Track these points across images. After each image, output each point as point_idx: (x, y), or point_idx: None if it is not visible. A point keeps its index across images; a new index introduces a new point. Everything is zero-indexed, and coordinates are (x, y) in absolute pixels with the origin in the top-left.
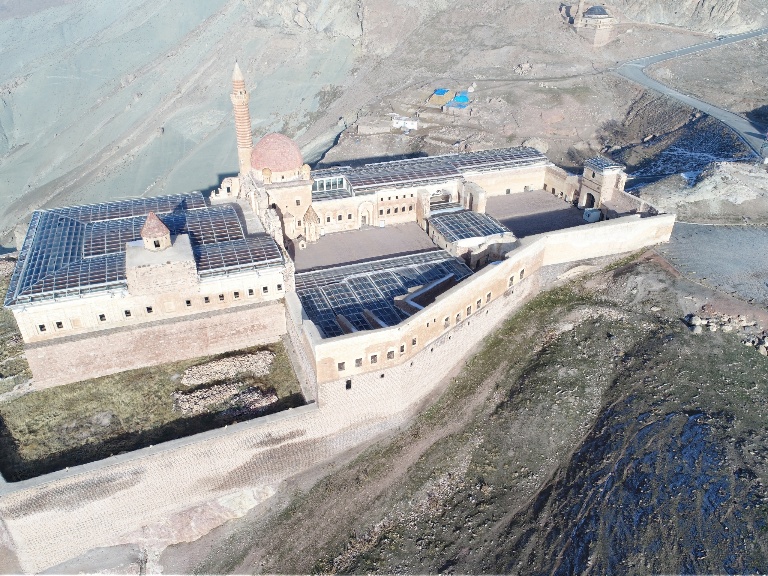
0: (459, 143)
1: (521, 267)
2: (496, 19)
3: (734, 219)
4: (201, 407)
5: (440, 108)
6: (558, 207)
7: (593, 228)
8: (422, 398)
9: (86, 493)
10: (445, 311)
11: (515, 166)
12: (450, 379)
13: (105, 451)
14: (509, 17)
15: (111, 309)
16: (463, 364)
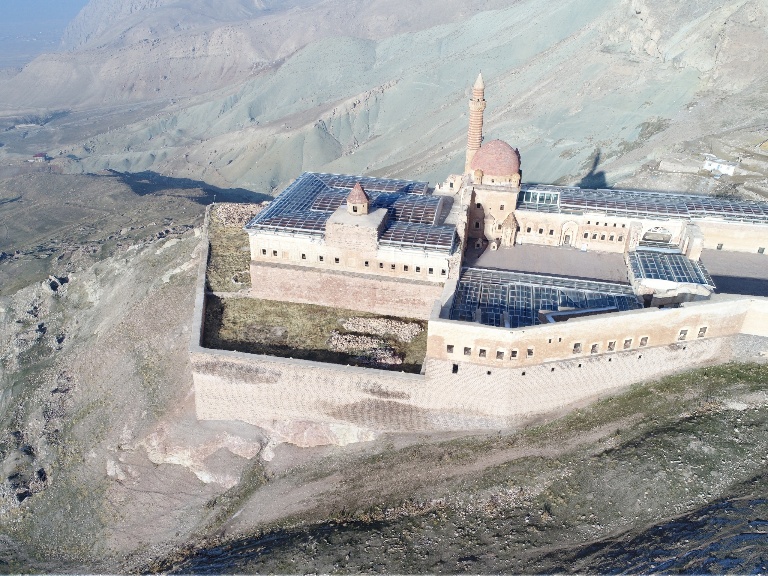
0: None
1: (702, 323)
2: None
3: None
4: (344, 347)
5: None
6: None
7: None
8: (534, 414)
9: (241, 374)
10: (576, 335)
11: None
12: (573, 409)
13: (266, 352)
14: None
15: (310, 251)
16: (594, 400)
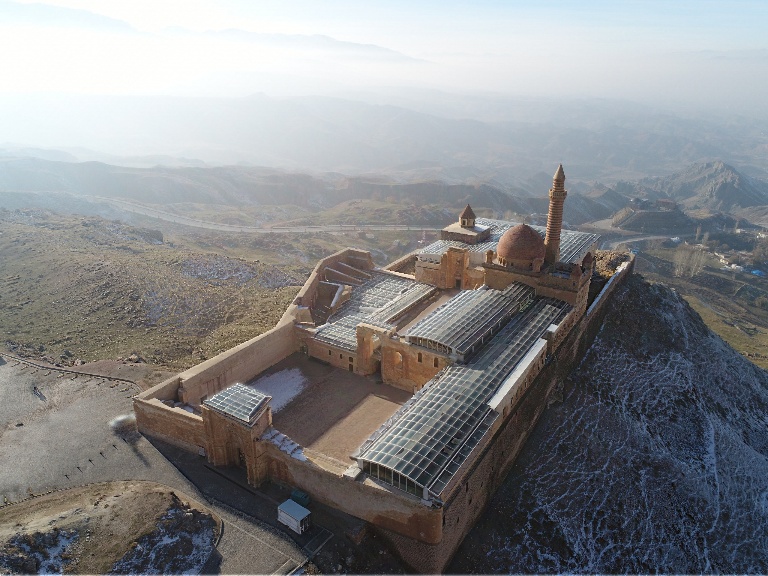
0: None
1: None
2: None
3: (7, 512)
4: None
5: None
6: None
7: (233, 348)
8: None
9: None
10: None
11: None
12: None
13: None
14: None
15: None
16: None
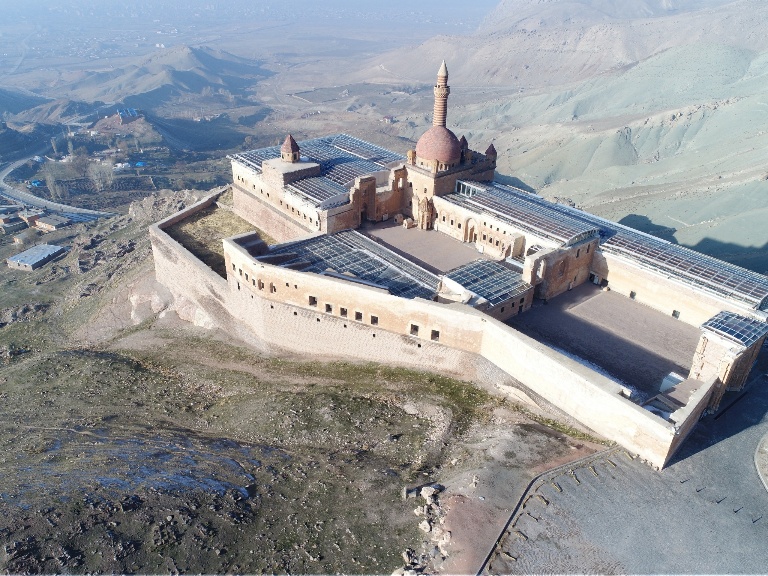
0: None
1: (432, 325)
2: None
3: None
4: None
5: None
6: (682, 360)
7: (537, 350)
8: (288, 350)
9: (165, 252)
10: (310, 288)
11: (697, 286)
12: (316, 359)
13: None
14: None
15: (256, 184)
16: (335, 360)
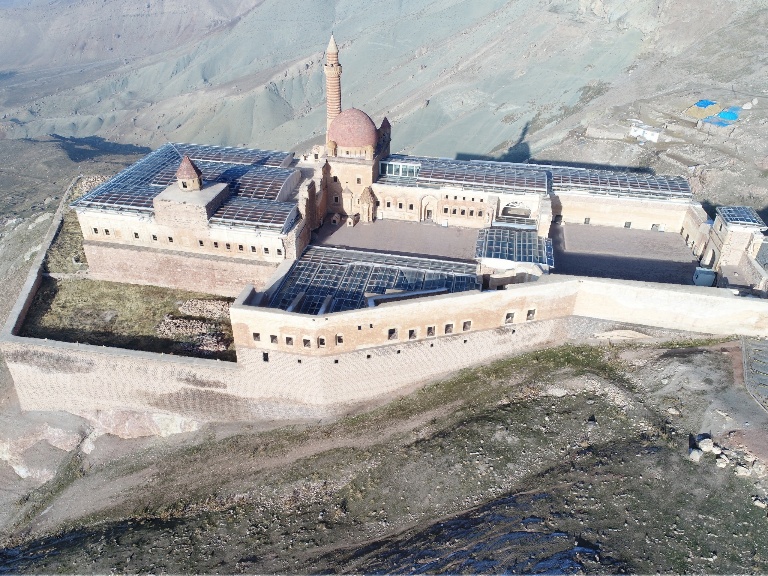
0: (696, 166)
1: (529, 306)
2: None
3: None
4: (171, 333)
5: (696, 122)
6: (674, 257)
7: (650, 288)
8: (356, 402)
9: (54, 364)
10: (389, 321)
11: (643, 196)
12: (397, 396)
13: (86, 339)
14: None
15: (142, 230)
16: (420, 386)
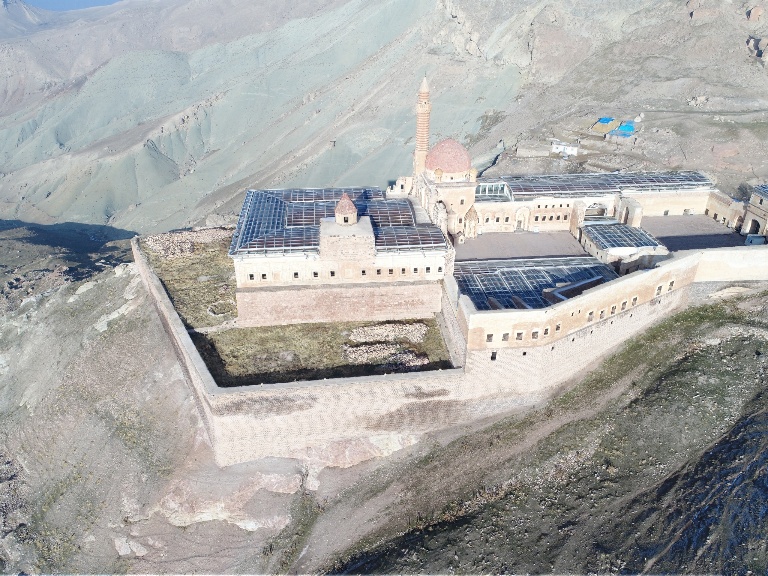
0: (619, 171)
1: (671, 278)
2: (673, 51)
3: None
4: (364, 359)
5: (603, 136)
6: (718, 232)
7: (753, 250)
8: (558, 384)
9: (272, 407)
10: (590, 305)
11: (676, 188)
12: (587, 372)
13: (288, 379)
14: (688, 49)
15: (304, 269)
16: (601, 361)
